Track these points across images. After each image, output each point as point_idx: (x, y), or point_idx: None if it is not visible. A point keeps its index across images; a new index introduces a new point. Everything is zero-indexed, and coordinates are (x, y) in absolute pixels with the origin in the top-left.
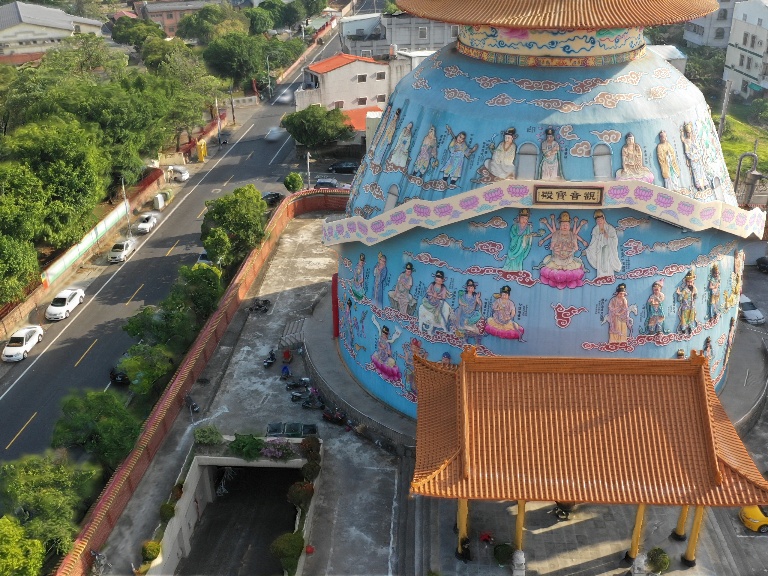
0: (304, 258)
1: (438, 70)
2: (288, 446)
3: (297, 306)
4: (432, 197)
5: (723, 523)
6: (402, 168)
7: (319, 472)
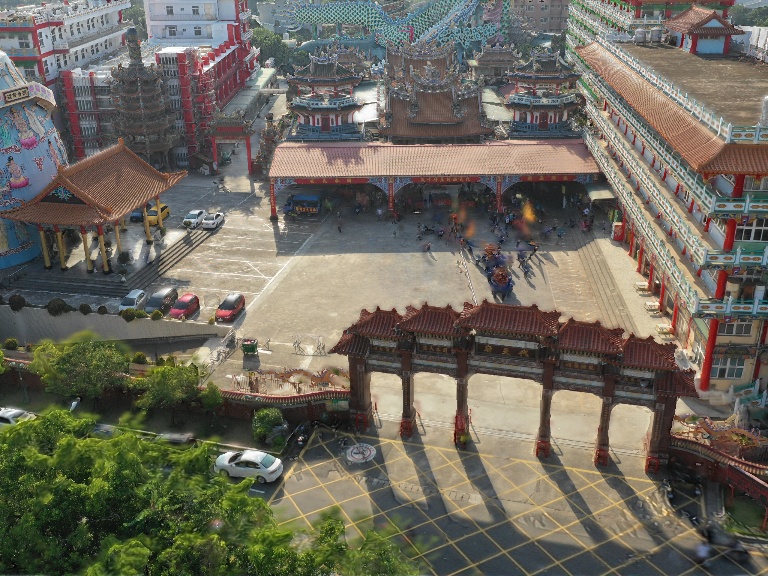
0: None
1: None
2: None
3: None
4: None
5: None
6: None
7: None
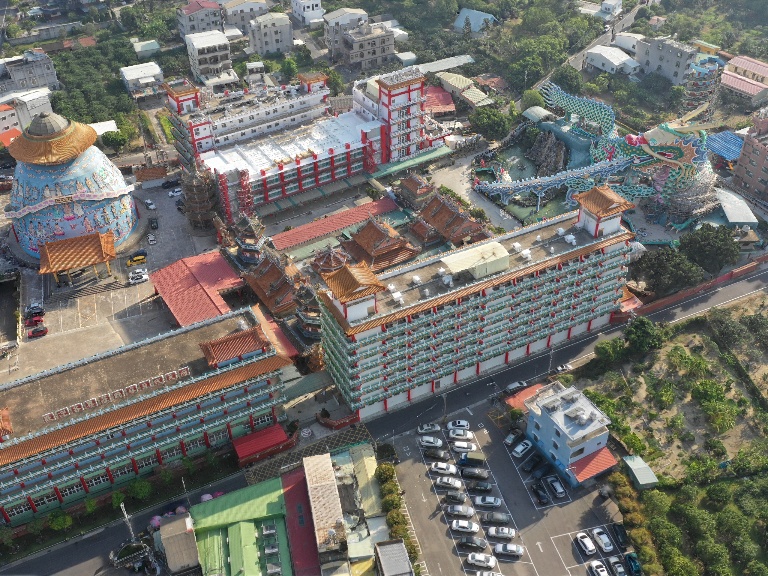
0: (0, 215)
1: (25, 167)
2: (11, 274)
3: (3, 234)
4: (32, 204)
5: (122, 266)
6: (22, 196)
7: (21, 279)
